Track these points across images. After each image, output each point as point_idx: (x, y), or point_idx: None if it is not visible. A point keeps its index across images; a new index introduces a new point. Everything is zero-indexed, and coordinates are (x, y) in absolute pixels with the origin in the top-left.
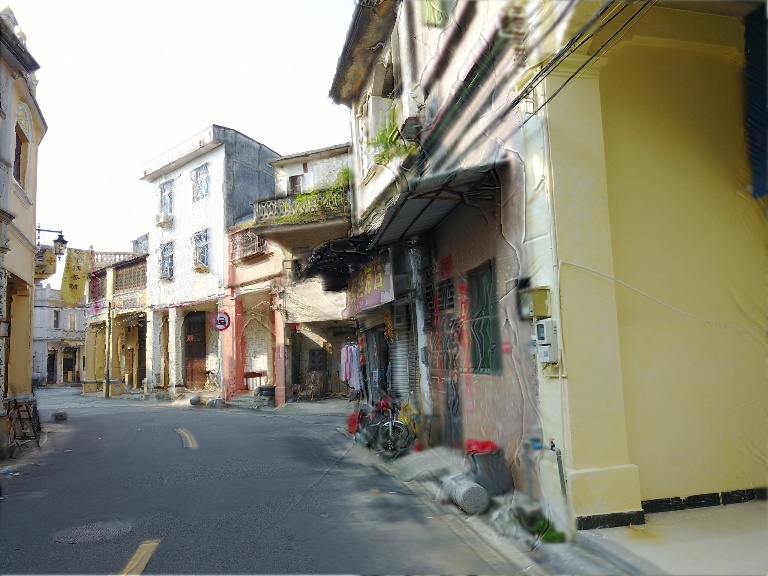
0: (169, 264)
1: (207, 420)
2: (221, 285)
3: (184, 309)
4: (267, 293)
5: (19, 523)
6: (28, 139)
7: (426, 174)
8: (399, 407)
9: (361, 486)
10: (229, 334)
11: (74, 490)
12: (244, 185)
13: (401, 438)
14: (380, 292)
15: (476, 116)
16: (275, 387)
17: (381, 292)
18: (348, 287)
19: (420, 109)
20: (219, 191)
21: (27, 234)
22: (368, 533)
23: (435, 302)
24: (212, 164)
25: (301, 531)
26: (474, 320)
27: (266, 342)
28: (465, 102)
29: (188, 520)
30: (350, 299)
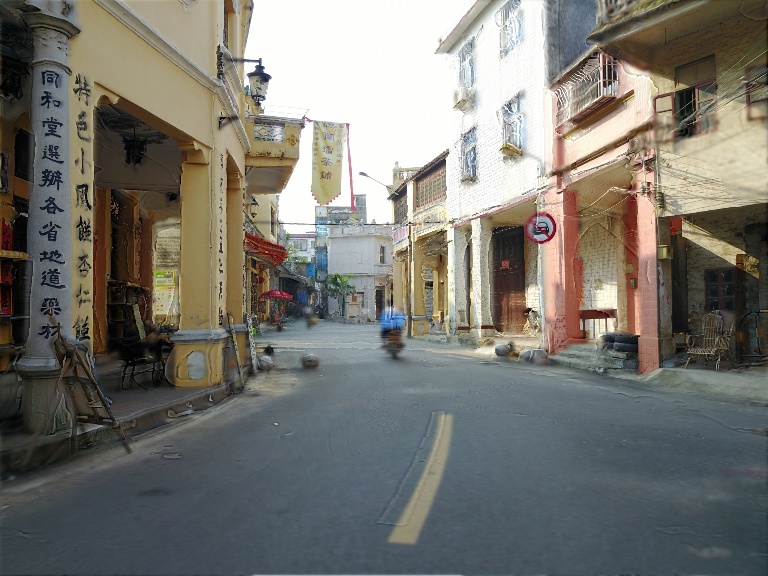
0: (472, 160)
1: (508, 392)
2: (541, 173)
3: (490, 219)
4: (620, 171)
5: None
6: None
7: None
8: None
9: None
10: (554, 249)
11: None
12: (577, 13)
13: None
14: None
15: None
16: (638, 336)
17: None
18: None
19: None
20: (537, 25)
21: (191, 53)
22: None
23: None
24: None
25: None
26: None
27: (615, 264)
28: None
29: None
30: None
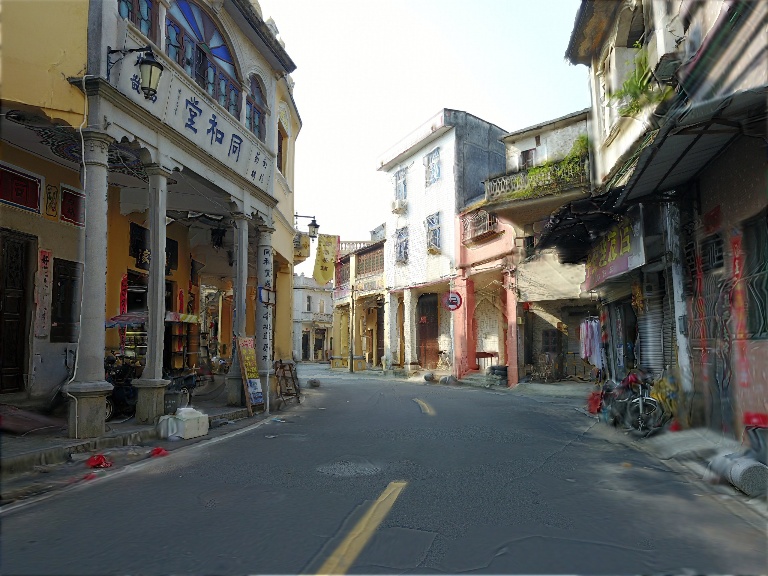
0: (404, 248)
1: (441, 394)
2: (453, 266)
3: (418, 290)
4: (498, 272)
5: (288, 455)
6: (287, 134)
7: (686, 117)
8: (651, 382)
9: (610, 458)
10: (461, 314)
11: (330, 436)
12: (474, 166)
13: (654, 417)
14: (627, 257)
15: (758, 30)
16: (507, 367)
17: (629, 256)
18: (588, 258)
19: (679, 43)
20: (450, 174)
21: (288, 218)
22: (624, 500)
23: (698, 262)
24: (443, 148)
25: (547, 489)
26: (753, 276)
27: (497, 323)
28: (742, 16)
29: (432, 468)
30: (590, 270)
